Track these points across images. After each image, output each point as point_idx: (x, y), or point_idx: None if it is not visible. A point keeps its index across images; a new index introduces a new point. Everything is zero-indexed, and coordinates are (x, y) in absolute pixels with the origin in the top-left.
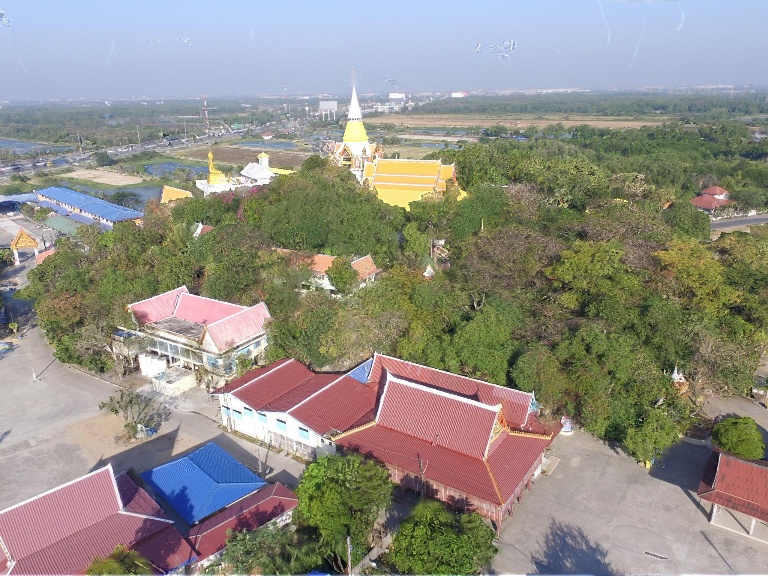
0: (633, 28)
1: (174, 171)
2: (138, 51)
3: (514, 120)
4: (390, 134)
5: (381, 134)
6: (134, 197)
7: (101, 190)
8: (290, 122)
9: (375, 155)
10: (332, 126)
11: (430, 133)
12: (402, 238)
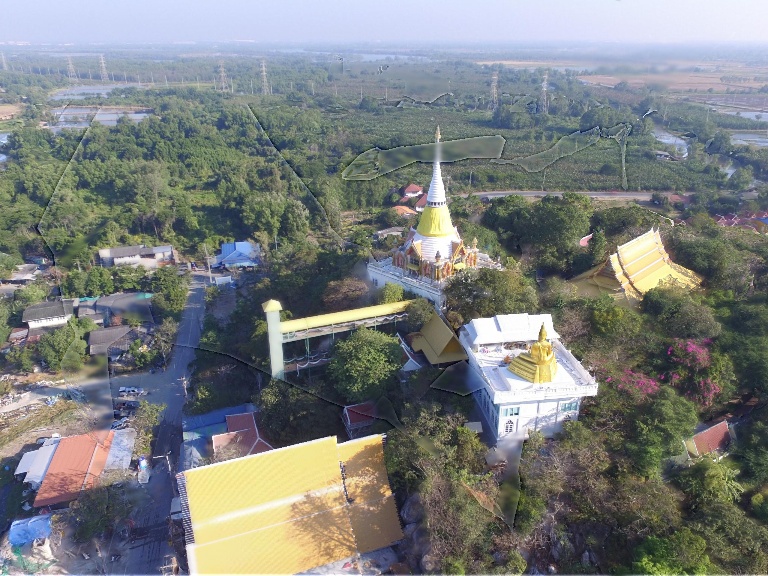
0: (660, 79)
1: None
2: None
3: None
4: None
5: None
6: None
7: None
8: None
9: None
10: None
11: None
12: None
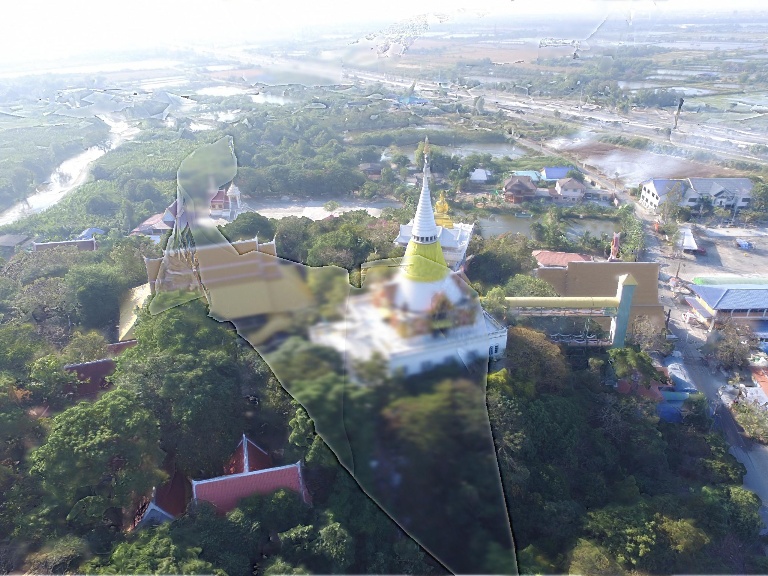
0: None
1: None
2: None
3: None
4: None
5: None
6: None
7: None
8: None
9: None
10: None
11: None
12: None
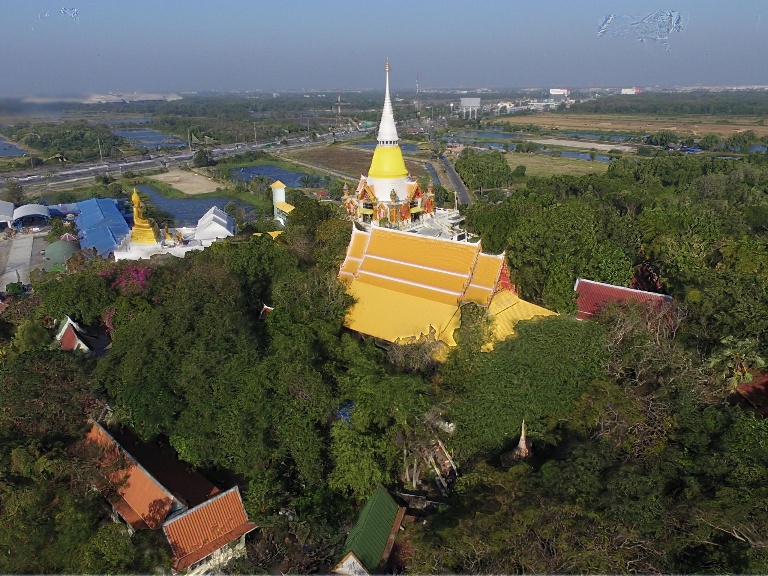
0: None
1: (252, 180)
2: (32, 33)
3: (690, 123)
4: (532, 138)
5: (521, 137)
6: (166, 218)
7: (167, 199)
8: (420, 121)
9: (416, 200)
10: (470, 126)
11: (580, 138)
12: (328, 444)
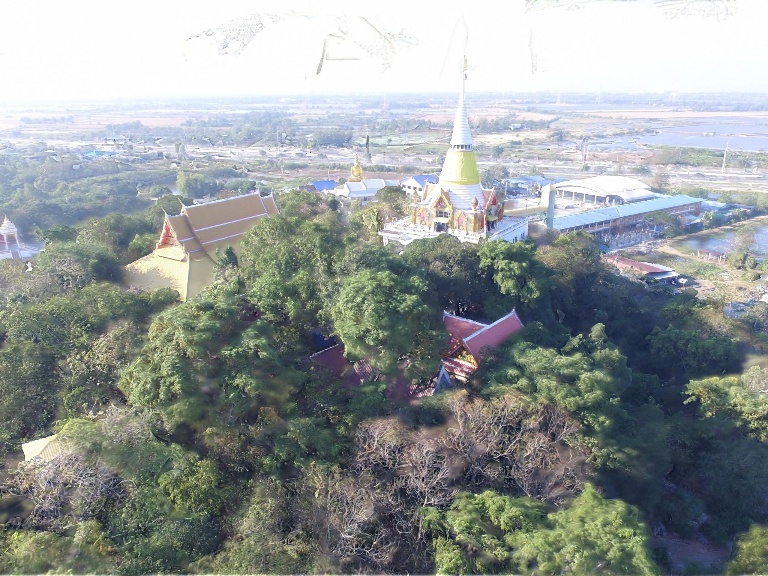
0: None
1: None
2: None
3: None
4: None
5: None
6: None
7: None
8: None
9: None
10: None
11: None
12: None
